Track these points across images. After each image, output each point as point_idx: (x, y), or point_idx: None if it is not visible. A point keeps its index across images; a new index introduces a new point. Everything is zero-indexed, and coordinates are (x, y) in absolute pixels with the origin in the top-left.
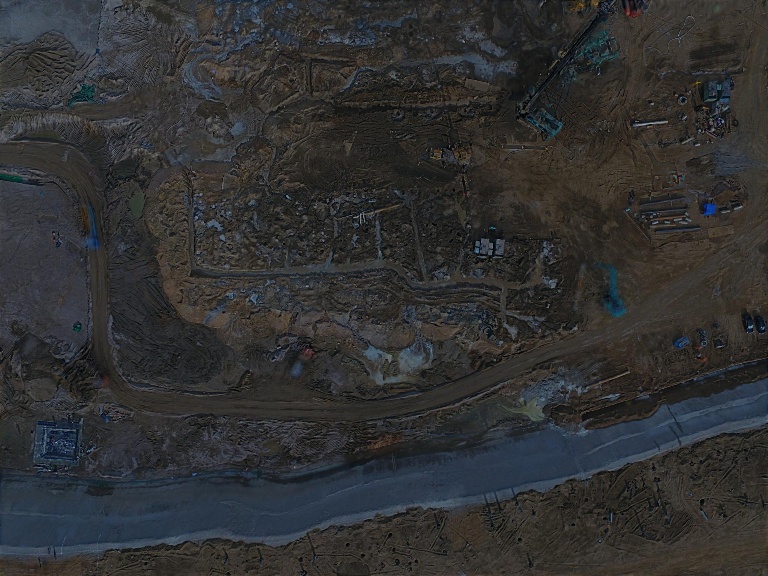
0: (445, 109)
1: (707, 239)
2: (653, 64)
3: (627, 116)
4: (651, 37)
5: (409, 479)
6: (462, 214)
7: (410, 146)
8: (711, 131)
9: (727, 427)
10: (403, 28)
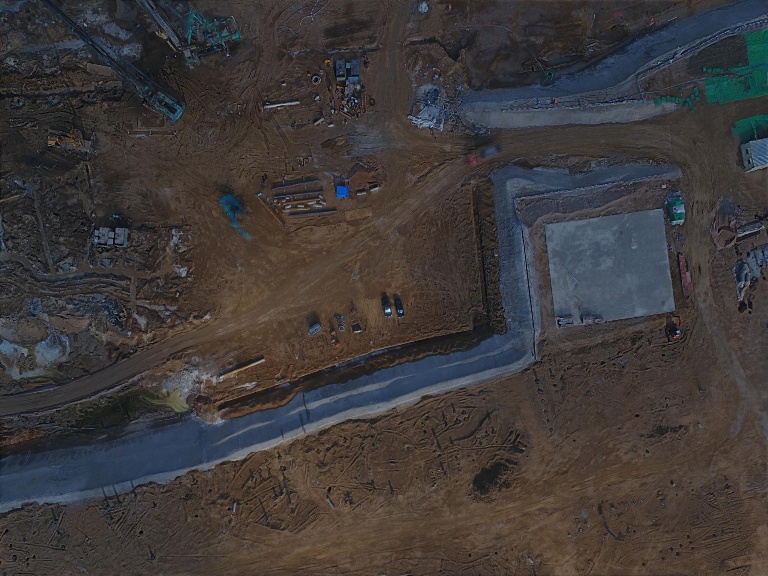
0: (65, 95)
1: (344, 222)
2: (285, 43)
3: (259, 98)
4: (283, 15)
5: (35, 474)
6: (87, 203)
7: (31, 134)
8: (344, 111)
9: (352, 413)
10: (20, 12)
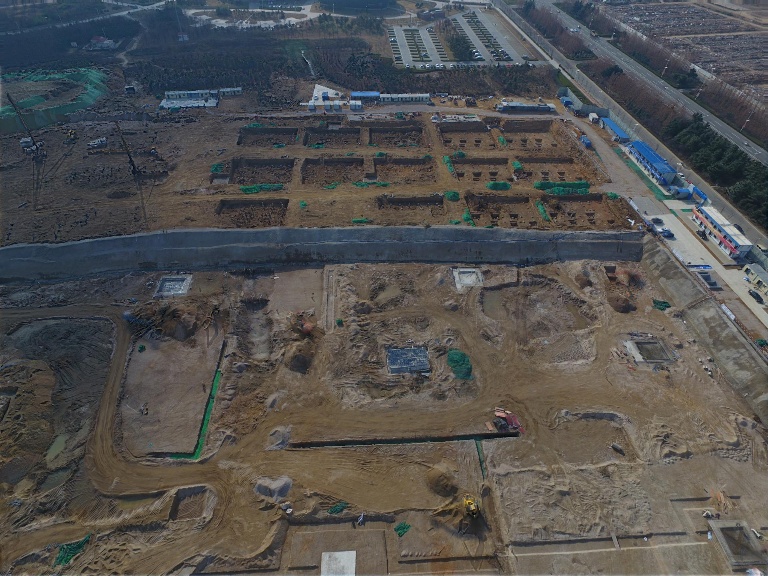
0: None
1: None
2: None
3: None
4: None
5: None
6: None
7: None
8: None
9: None
10: None
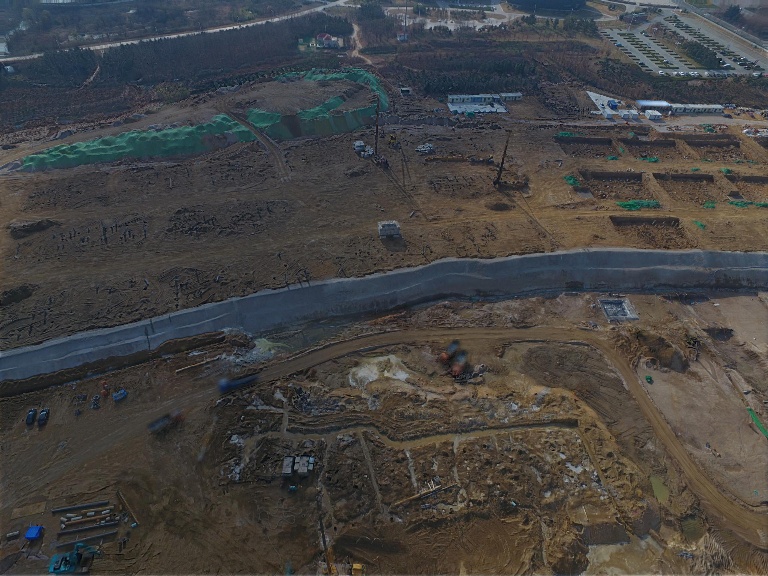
0: None
1: (50, 500)
2: None
3: None
4: None
5: (364, 295)
6: (326, 502)
7: None
8: None
9: (107, 331)
10: None
